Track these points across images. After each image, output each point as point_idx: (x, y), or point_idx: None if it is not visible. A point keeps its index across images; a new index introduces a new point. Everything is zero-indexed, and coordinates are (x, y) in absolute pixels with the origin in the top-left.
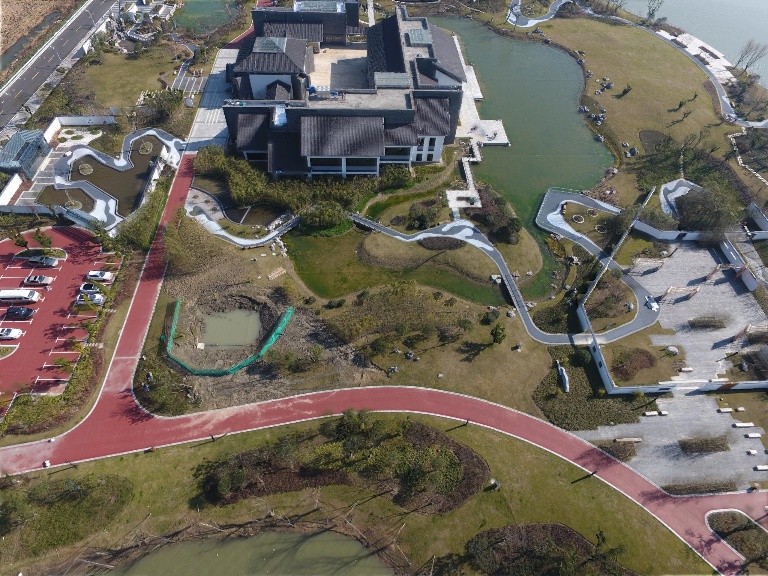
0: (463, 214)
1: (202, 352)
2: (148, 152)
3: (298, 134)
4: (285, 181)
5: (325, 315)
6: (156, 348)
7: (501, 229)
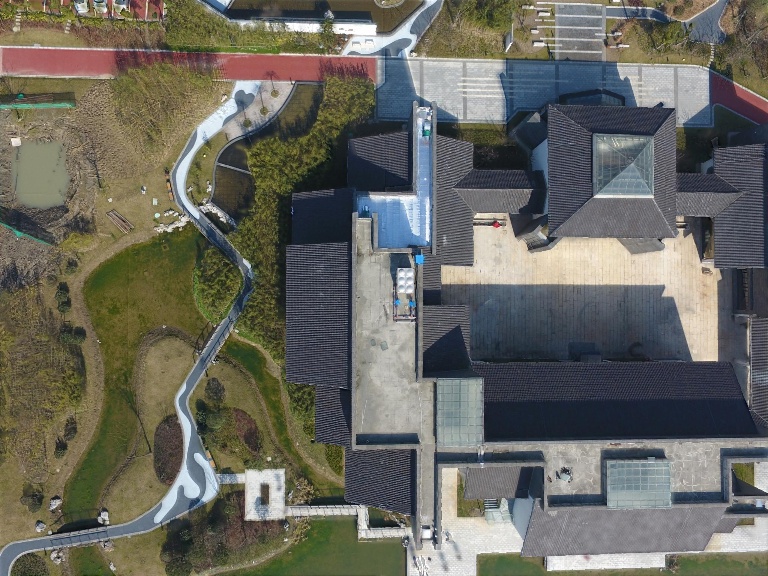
0: (230, 489)
1: (5, 145)
2: (379, 3)
3: (350, 237)
4: (278, 221)
5: (47, 287)
6: (8, 92)
7: (185, 543)
